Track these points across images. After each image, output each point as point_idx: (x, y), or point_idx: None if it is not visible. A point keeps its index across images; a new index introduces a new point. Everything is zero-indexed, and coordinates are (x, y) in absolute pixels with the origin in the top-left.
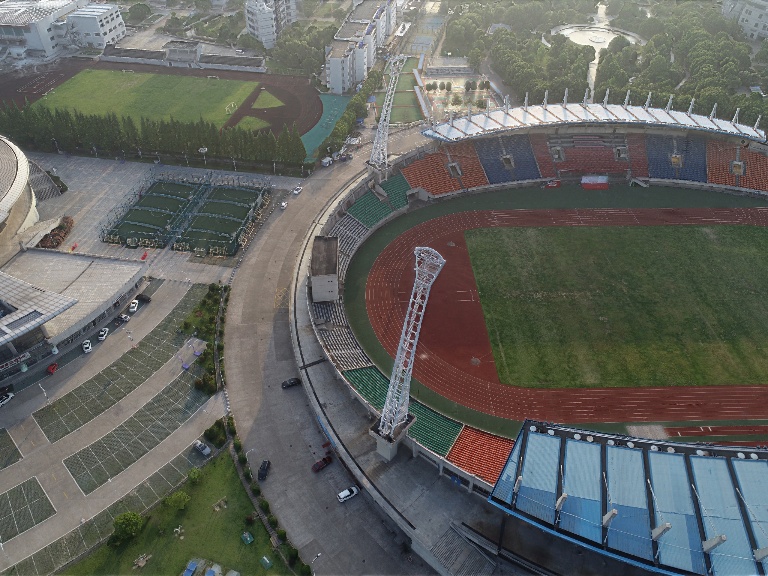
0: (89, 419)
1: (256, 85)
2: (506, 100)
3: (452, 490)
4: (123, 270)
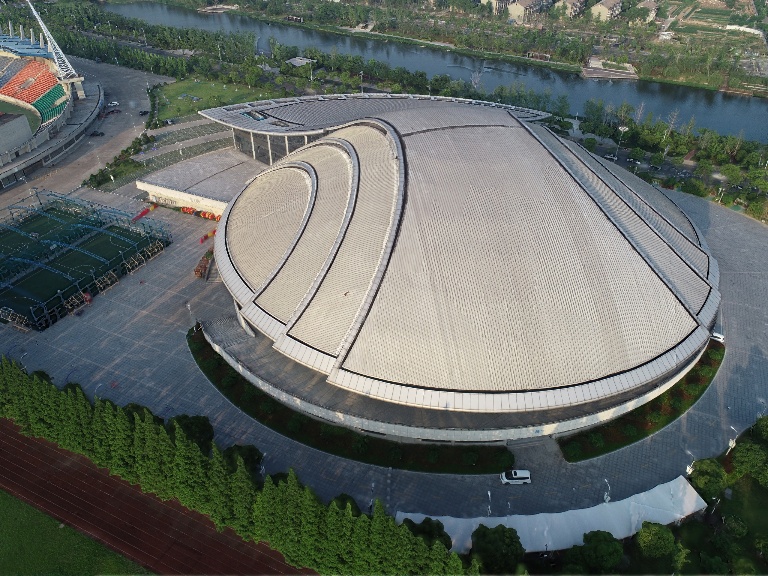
0: None
1: None
2: None
3: None
4: (162, 179)
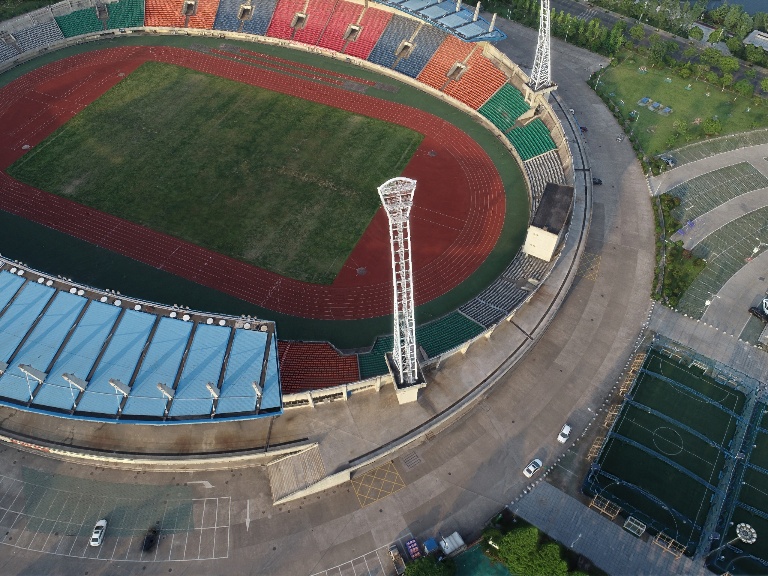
0: (767, 208)
1: None
2: (73, 379)
3: None
4: None
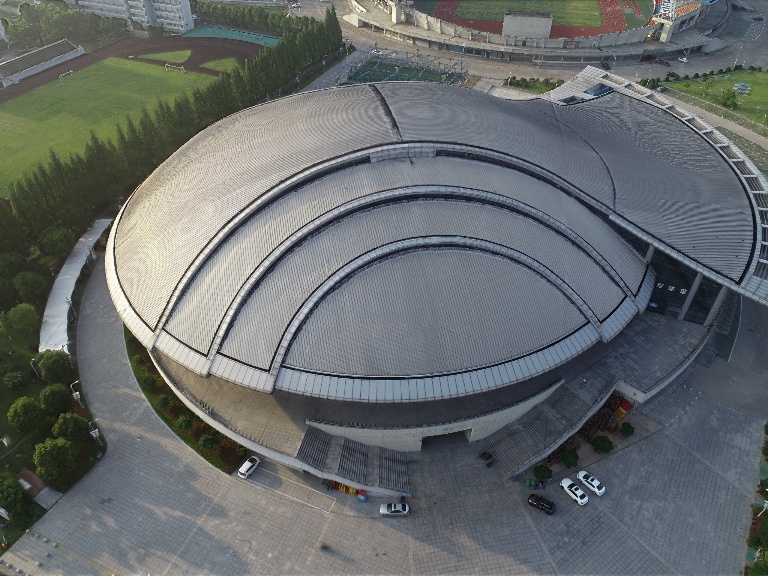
0: None
1: (118, 58)
2: None
3: (683, 33)
4: (500, 94)
